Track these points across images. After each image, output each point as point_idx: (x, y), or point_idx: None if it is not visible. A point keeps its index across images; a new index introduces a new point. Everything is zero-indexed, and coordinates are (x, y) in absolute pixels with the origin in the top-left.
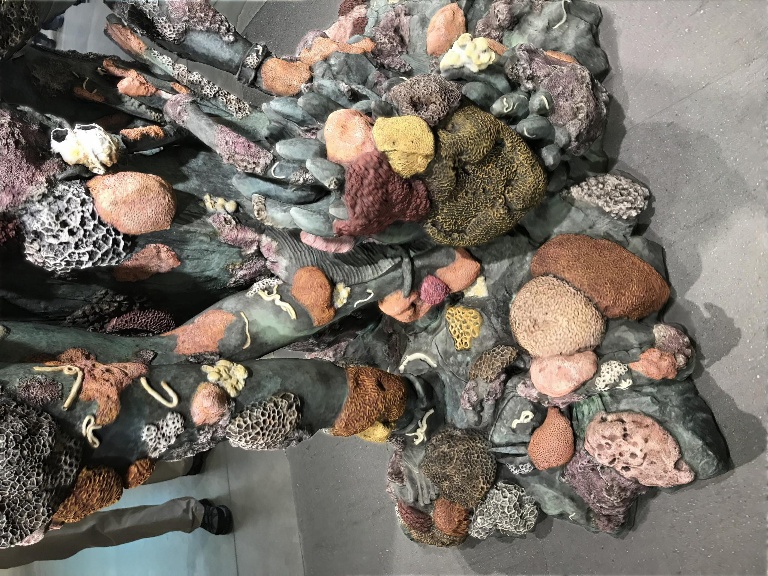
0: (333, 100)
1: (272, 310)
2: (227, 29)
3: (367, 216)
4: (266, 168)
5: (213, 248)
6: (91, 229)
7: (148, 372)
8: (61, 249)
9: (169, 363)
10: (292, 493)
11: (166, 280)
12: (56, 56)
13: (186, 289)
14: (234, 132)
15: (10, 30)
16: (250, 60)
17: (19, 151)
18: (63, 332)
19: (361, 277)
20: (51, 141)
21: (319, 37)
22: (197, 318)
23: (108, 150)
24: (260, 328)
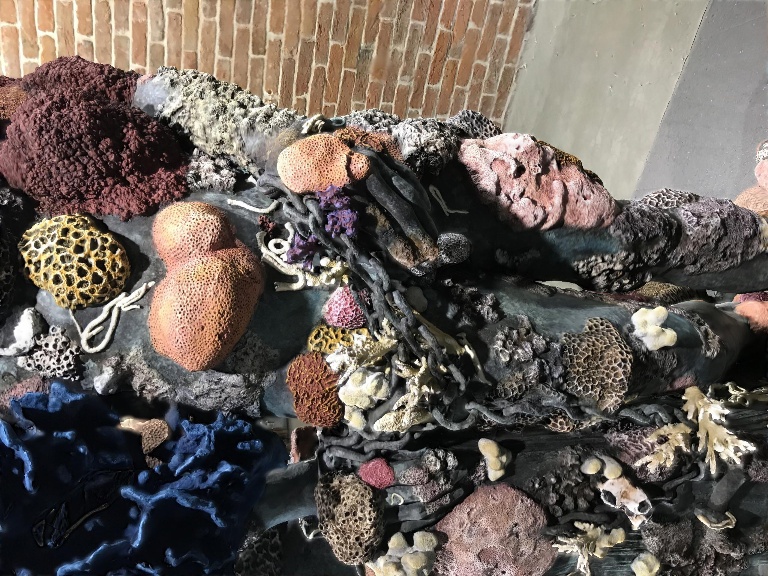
0: None
1: None
2: None
3: None
4: None
5: None
6: None
7: None
8: None
9: None
10: None
11: None
12: None
13: None
14: None
15: None
16: None
17: None
18: None
19: None
20: None
21: None
22: None
23: None
24: None
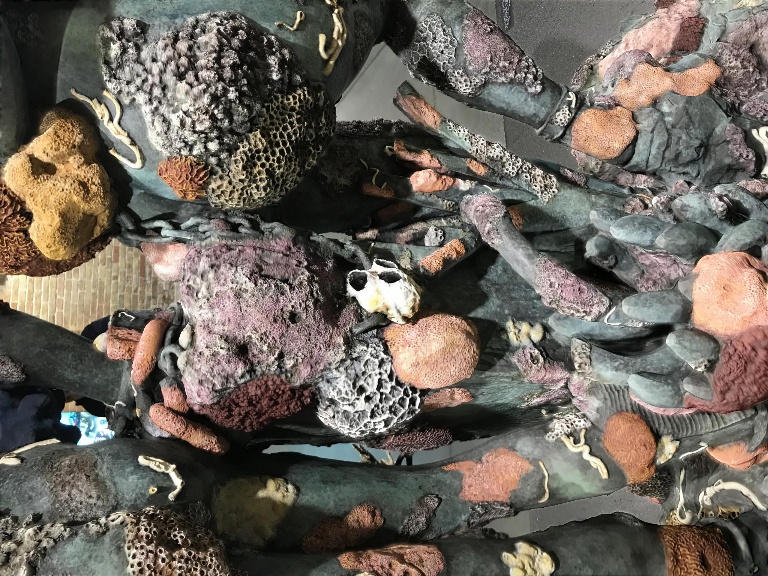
0: (699, 223)
1: (578, 464)
2: (534, 77)
3: (741, 403)
4: (599, 316)
5: (513, 385)
6: (388, 392)
7: (446, 568)
8: (356, 418)
9: (454, 510)
10: (530, 524)
11: (453, 409)
12: (343, 139)
13: (472, 413)
14: (560, 268)
15: (308, 154)
16: (560, 116)
17: (317, 312)
18: (348, 483)
19: (696, 429)
20: (347, 284)
21: (644, 64)
22: (485, 455)
23: (412, 303)
24: (562, 484)
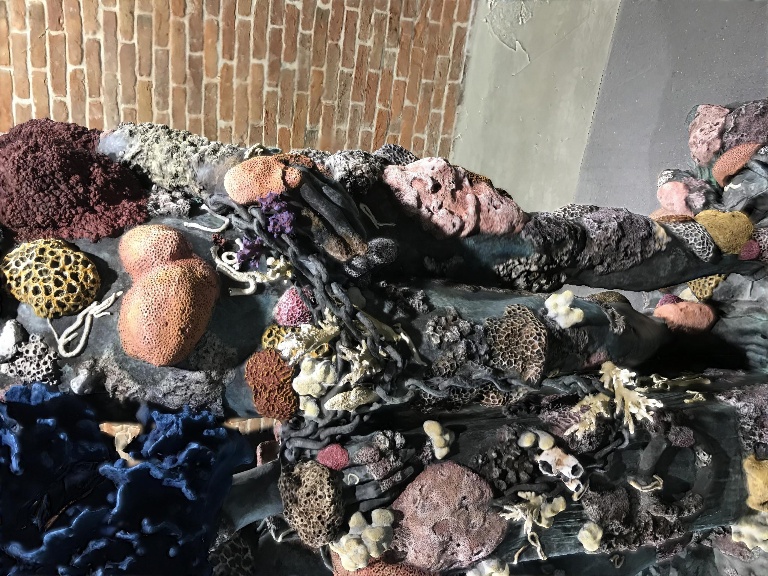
0: None
1: None
2: None
3: None
4: None
5: None
6: None
7: None
8: None
9: None
10: None
11: None
12: None
13: None
14: None
15: None
16: None
17: None
18: None
19: None
20: None
21: None
22: None
23: None
24: None
